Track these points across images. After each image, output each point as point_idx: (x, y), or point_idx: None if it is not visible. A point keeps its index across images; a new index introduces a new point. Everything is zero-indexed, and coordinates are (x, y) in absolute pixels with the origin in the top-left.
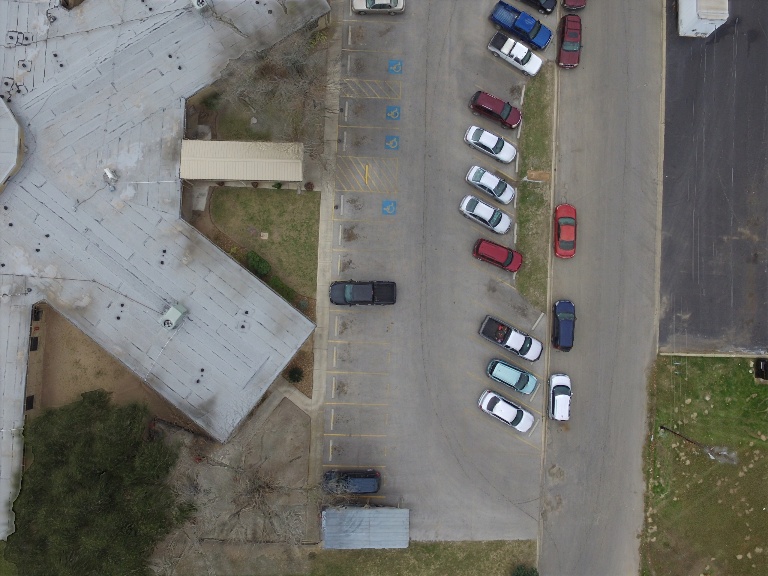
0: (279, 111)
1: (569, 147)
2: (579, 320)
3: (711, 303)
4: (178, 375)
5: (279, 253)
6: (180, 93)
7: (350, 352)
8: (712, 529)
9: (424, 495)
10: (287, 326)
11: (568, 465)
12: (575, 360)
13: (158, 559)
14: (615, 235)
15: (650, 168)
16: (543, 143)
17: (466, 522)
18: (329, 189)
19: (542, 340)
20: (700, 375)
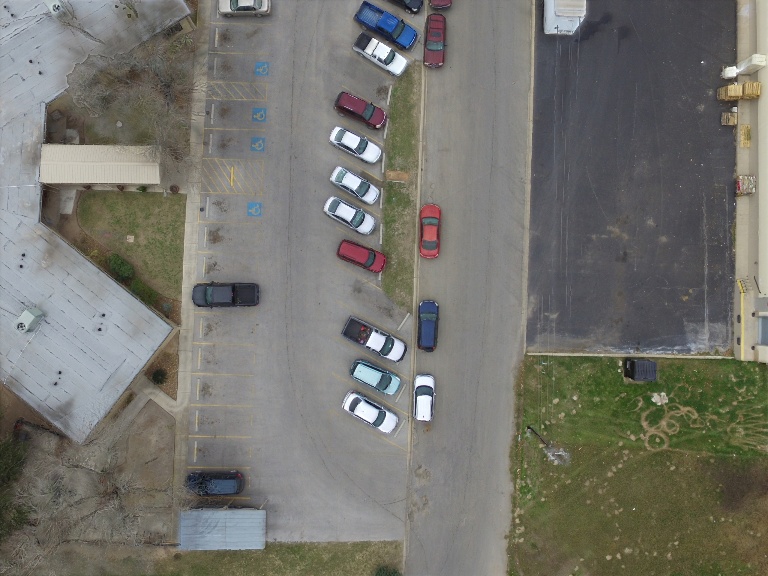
0: (141, 114)
1: (436, 147)
2: (445, 320)
3: (579, 302)
4: (37, 378)
5: (145, 256)
6: (40, 98)
7: (215, 354)
8: (581, 530)
9: (289, 496)
10: (144, 328)
11: (434, 466)
12: (441, 360)
13: (0, 560)
14: (482, 234)
15: (518, 167)
16: (410, 143)
17: (331, 523)
18: (195, 191)
19: (408, 340)
20: (568, 375)
